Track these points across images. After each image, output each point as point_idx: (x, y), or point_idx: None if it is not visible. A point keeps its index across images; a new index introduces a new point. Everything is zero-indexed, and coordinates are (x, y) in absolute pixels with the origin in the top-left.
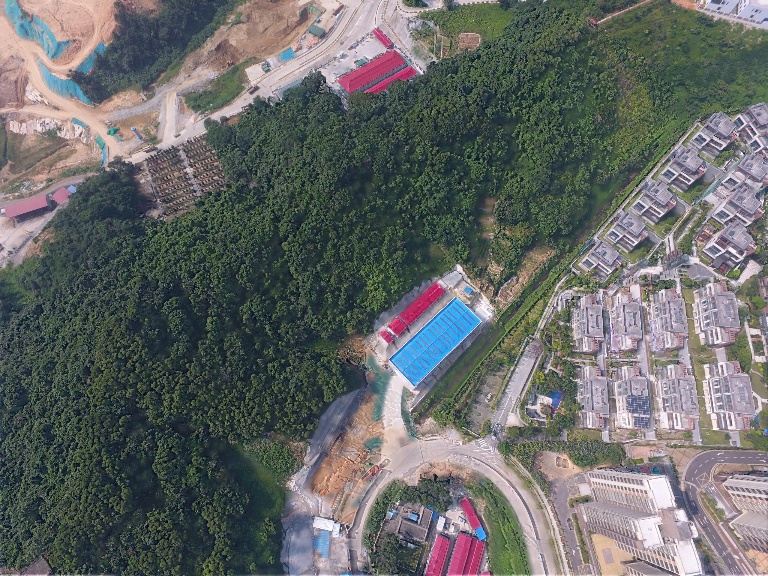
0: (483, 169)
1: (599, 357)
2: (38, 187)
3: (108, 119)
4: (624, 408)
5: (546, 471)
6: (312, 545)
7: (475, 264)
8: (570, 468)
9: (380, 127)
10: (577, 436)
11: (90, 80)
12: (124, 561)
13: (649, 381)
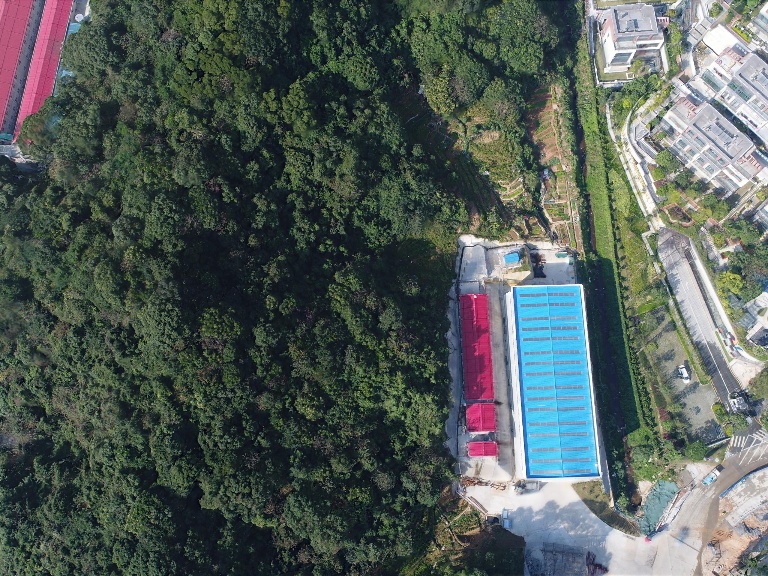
0: (366, 60)
1: (761, 174)
2: None
3: None
4: None
5: None
6: None
7: (482, 211)
8: None
9: (140, 147)
10: None
11: None
12: None
13: None
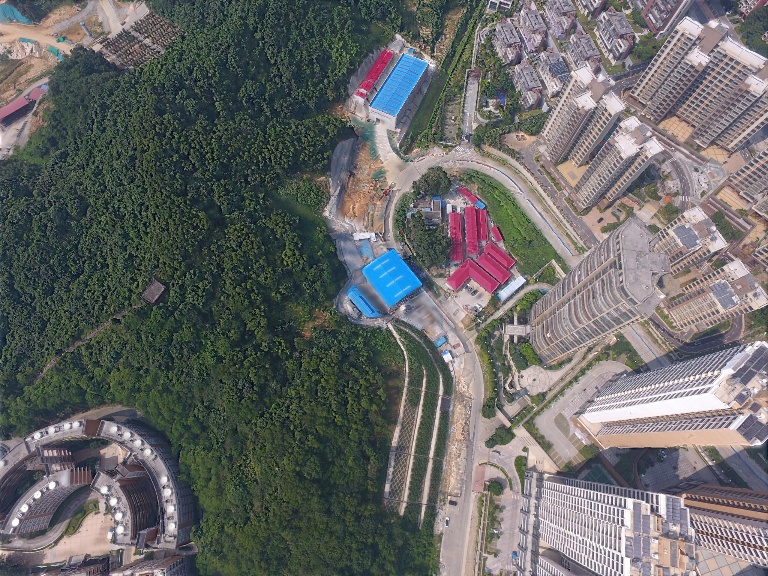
0: None
1: None
2: (11, 97)
3: (52, 32)
4: (550, 77)
5: (512, 147)
6: (358, 253)
7: (409, 31)
8: (528, 139)
9: None
10: (525, 117)
11: (23, 1)
12: (220, 267)
13: (561, 57)
